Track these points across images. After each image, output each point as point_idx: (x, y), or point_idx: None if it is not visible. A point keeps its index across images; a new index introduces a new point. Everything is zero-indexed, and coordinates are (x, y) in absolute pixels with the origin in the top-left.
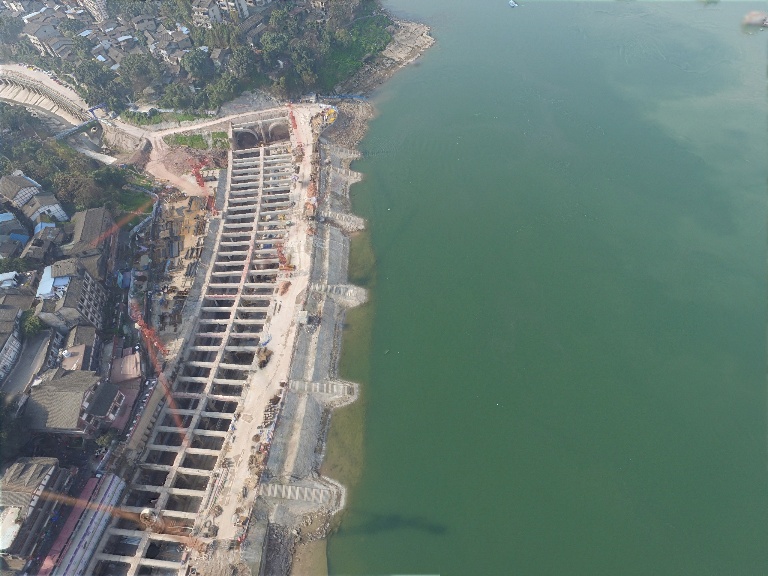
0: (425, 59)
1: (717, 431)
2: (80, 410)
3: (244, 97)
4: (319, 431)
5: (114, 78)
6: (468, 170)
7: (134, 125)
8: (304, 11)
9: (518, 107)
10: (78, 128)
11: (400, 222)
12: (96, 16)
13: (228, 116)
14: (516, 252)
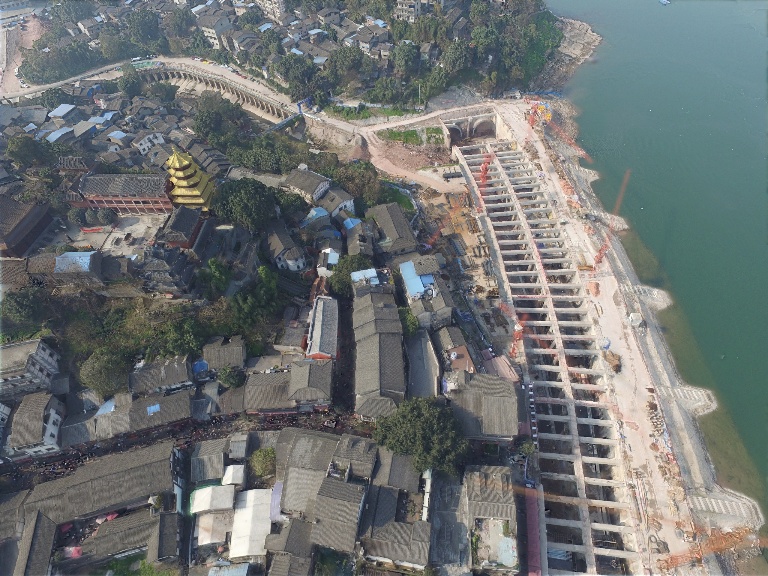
0: (600, 56)
1: None
2: None
3: (451, 92)
4: (699, 440)
5: (316, 72)
6: (708, 169)
7: (342, 120)
8: None
9: (727, 105)
10: (286, 122)
11: (663, 222)
12: (268, 9)
13: (435, 111)
14: None
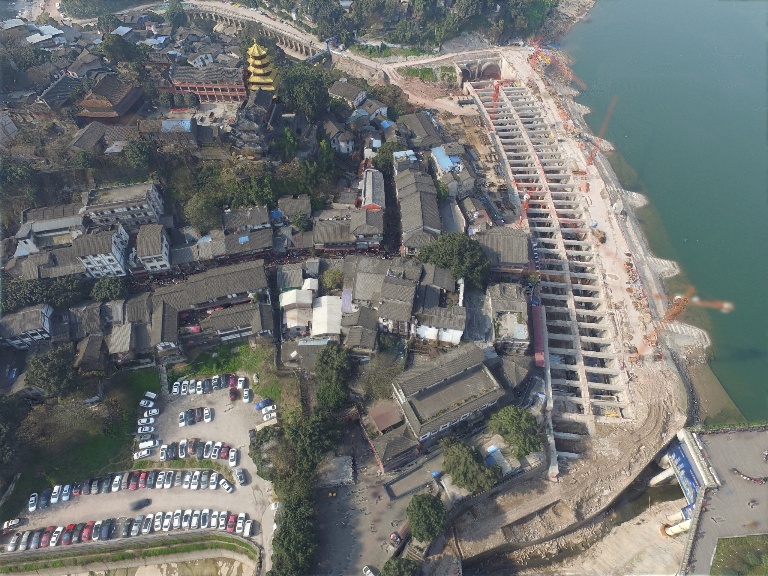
0: (593, 17)
1: None
2: None
3: (462, 37)
4: (664, 292)
5: (342, 14)
6: (683, 108)
7: (365, 57)
8: None
9: (702, 60)
10: (315, 57)
11: (643, 146)
12: None
13: (448, 54)
14: (759, 171)
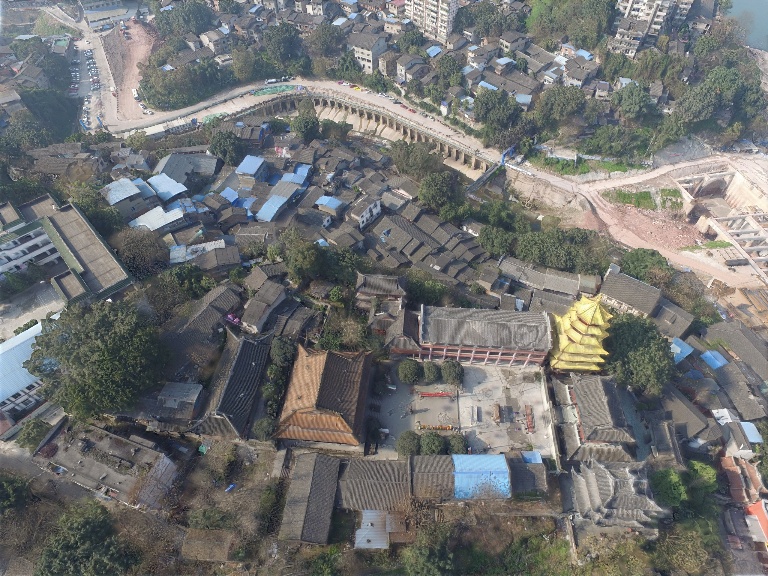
0: None
1: None
2: None
3: (680, 144)
4: None
5: (519, 113)
6: None
7: (554, 174)
8: (690, 34)
9: None
10: (489, 176)
11: None
12: (427, 27)
13: (662, 167)
14: None
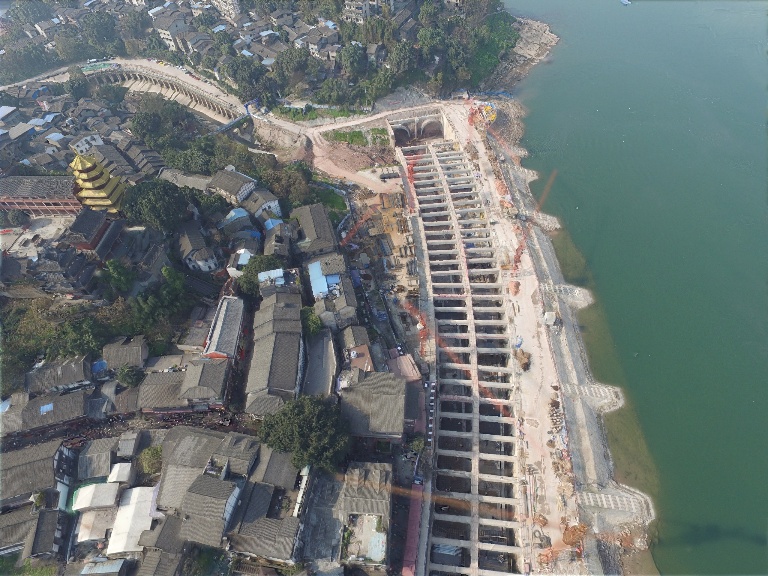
0: (555, 56)
1: None
2: (403, 414)
3: (398, 93)
4: (601, 437)
5: (265, 73)
6: (646, 169)
7: (289, 121)
8: (440, 7)
9: (673, 105)
10: (233, 124)
11: (596, 221)
12: (224, 11)
13: (382, 112)
14: (732, 253)
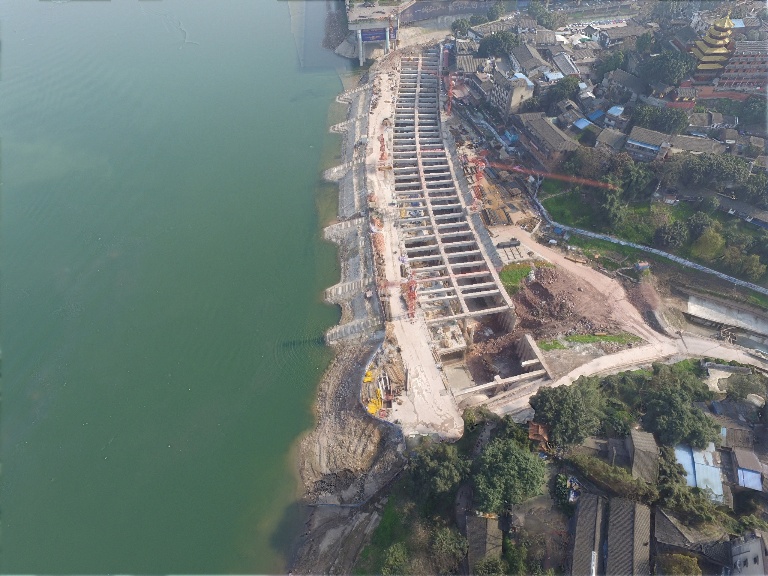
0: None
1: (141, 123)
2: None
3: None
4: None
5: None
6: (187, 307)
7: None
8: None
9: (21, 466)
10: None
11: (287, 237)
12: None
13: None
14: (189, 208)
